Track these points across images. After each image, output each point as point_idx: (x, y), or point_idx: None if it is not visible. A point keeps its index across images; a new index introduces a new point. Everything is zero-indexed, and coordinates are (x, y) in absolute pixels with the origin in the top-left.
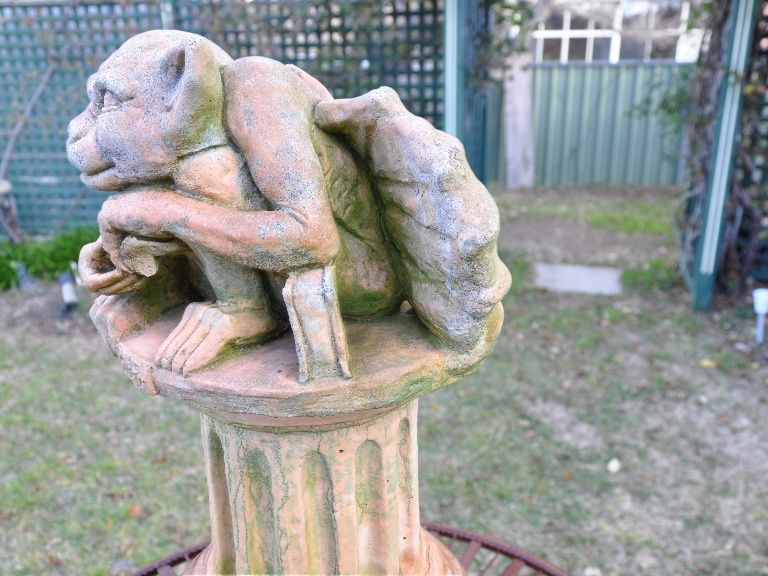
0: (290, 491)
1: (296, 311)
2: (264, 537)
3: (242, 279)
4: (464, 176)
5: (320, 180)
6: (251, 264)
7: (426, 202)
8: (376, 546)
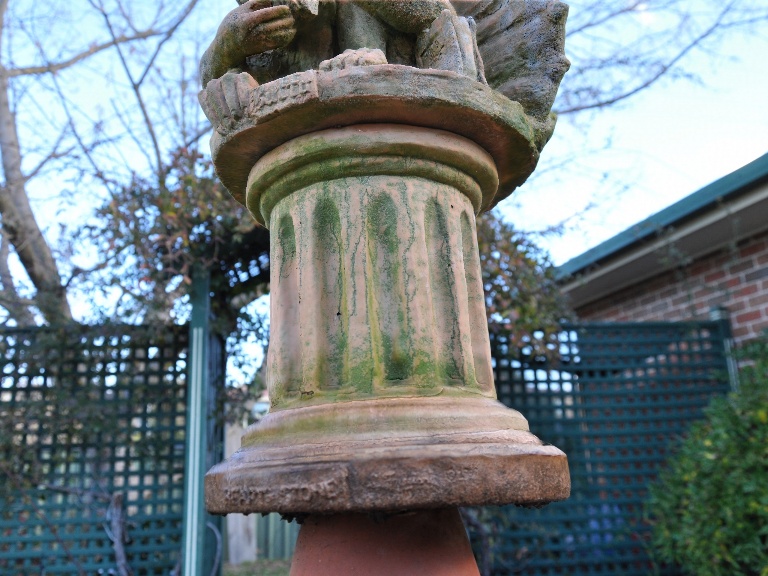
0: (416, 232)
1: (453, 25)
2: (380, 302)
3: (378, 43)
4: None
5: None
6: (405, 9)
7: (515, 1)
8: (474, 334)
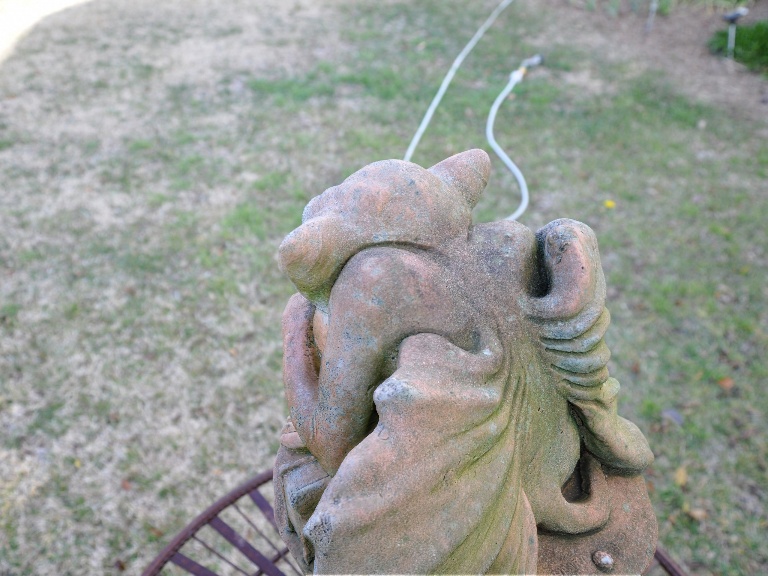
0: None
1: None
2: None
3: None
4: (326, 554)
5: (349, 411)
6: None
7: None
8: None
